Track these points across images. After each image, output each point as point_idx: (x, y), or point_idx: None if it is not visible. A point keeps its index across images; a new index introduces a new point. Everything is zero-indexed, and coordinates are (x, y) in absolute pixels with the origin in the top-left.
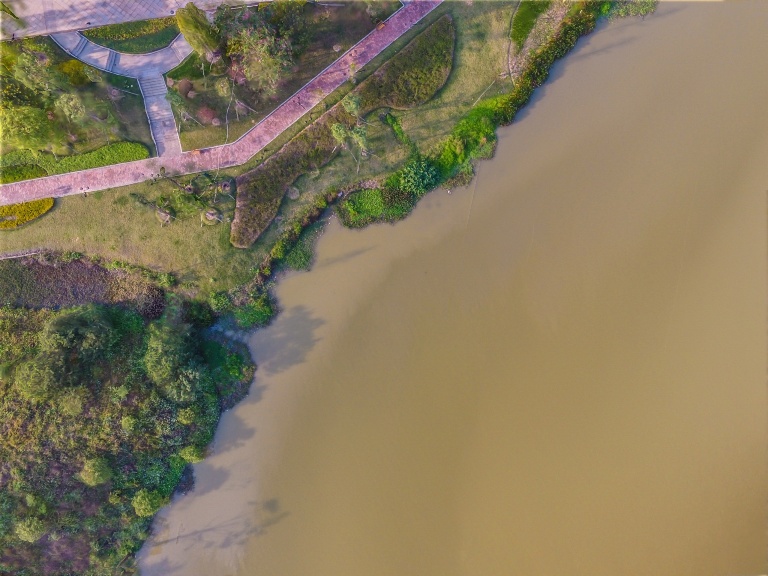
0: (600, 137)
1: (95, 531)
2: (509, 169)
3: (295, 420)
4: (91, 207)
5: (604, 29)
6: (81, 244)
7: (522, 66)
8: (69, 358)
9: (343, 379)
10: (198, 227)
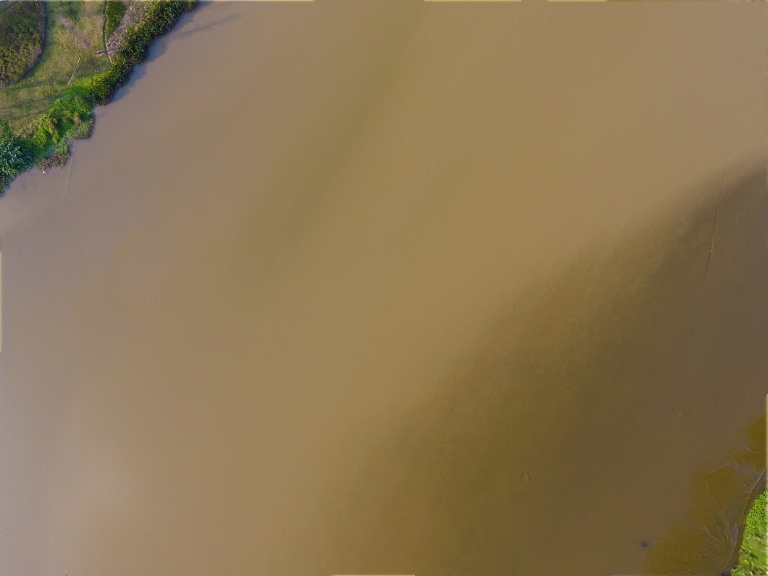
0: (201, 116)
1: None
2: (108, 149)
3: None
4: None
5: (208, 6)
6: None
7: (119, 44)
8: None
9: None
10: None
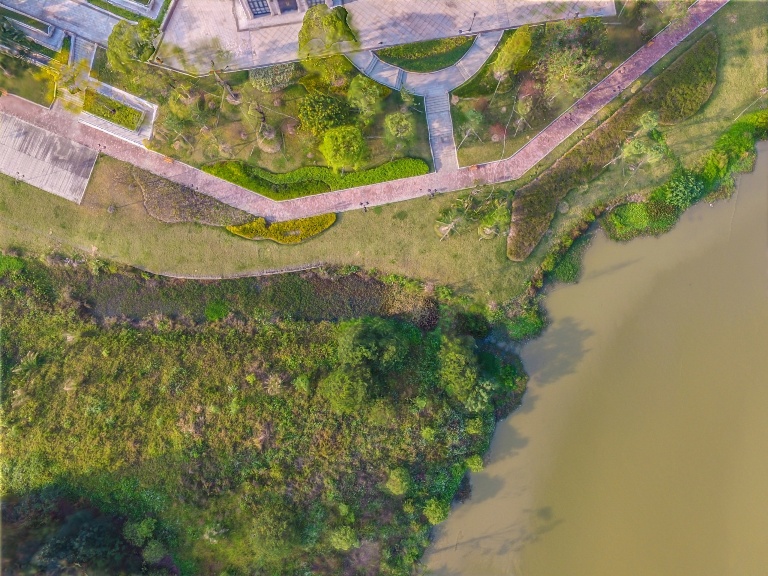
0: None
1: (387, 539)
2: (767, 182)
3: (567, 429)
4: (371, 222)
5: None
6: (361, 258)
7: None
8: (373, 370)
9: (613, 389)
10: (476, 241)
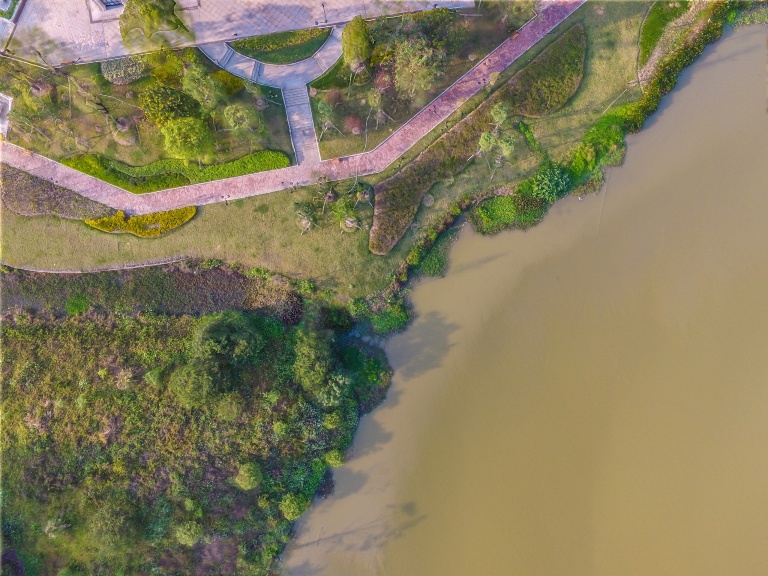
0: (727, 144)
1: (243, 534)
2: (638, 176)
3: (432, 424)
4: (232, 215)
5: (730, 37)
6: (222, 252)
7: (650, 74)
8: (223, 364)
9: (479, 384)
10: (337, 234)
